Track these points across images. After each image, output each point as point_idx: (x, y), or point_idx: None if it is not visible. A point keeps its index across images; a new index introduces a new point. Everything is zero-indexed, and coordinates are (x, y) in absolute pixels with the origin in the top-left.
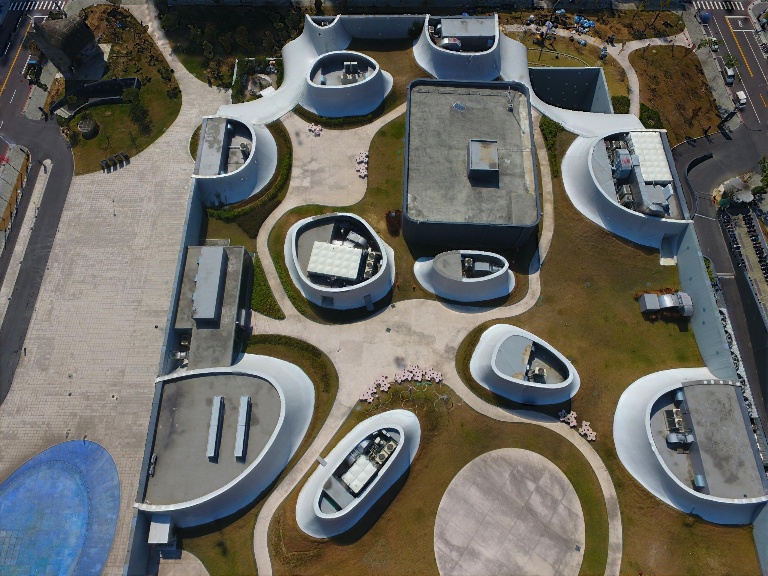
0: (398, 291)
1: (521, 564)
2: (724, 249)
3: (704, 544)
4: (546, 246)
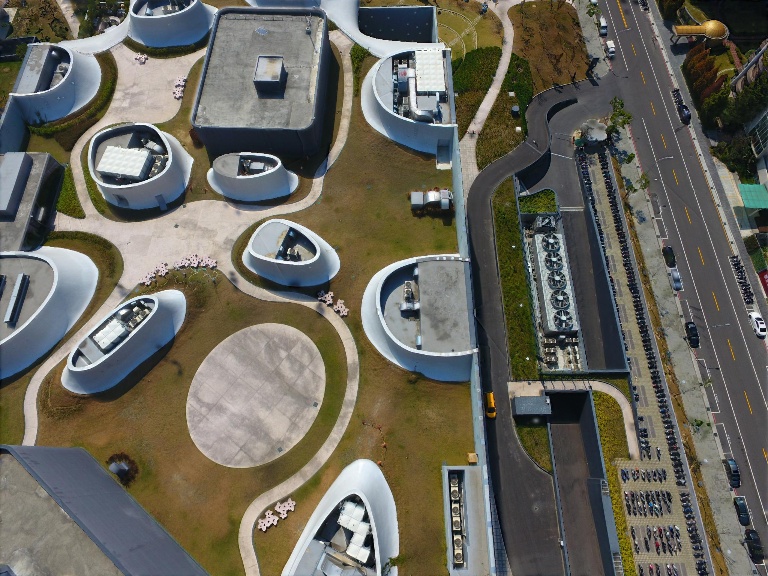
0: (191, 193)
1: (262, 417)
2: (577, 185)
3: (426, 398)
4: (335, 155)
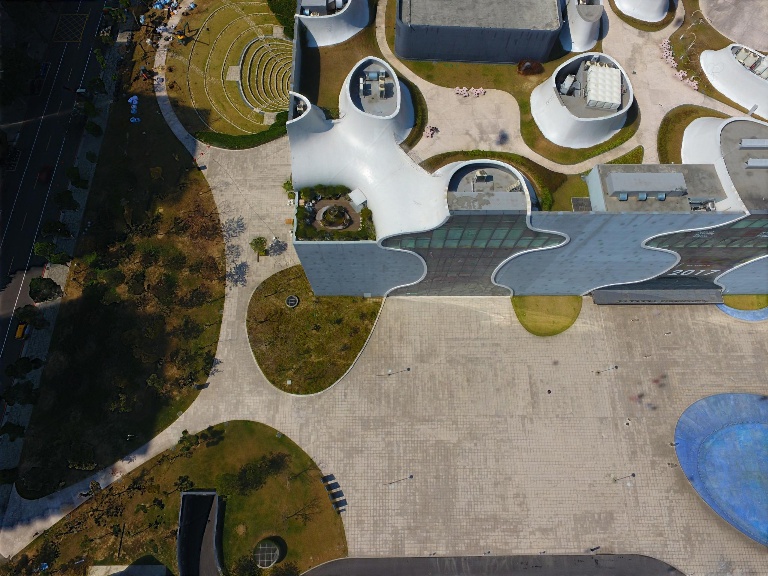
0: None
1: None
2: None
3: None
4: None
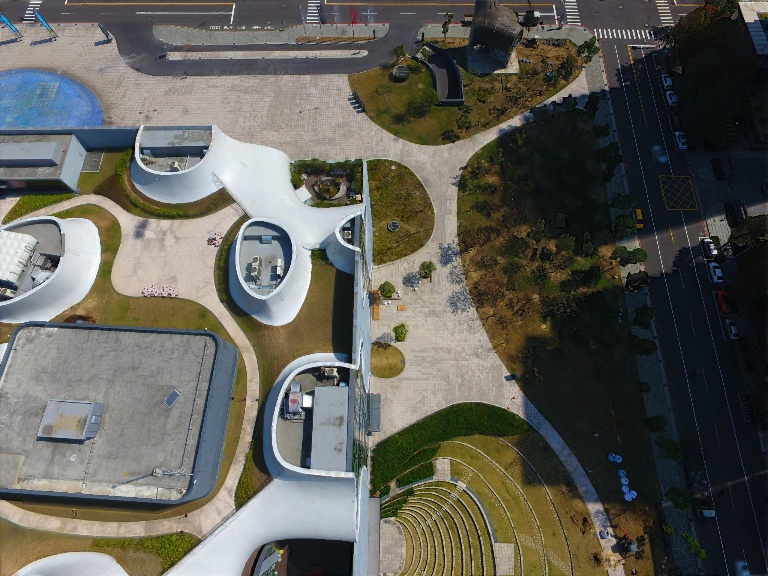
0: None
1: None
2: None
3: None
4: None
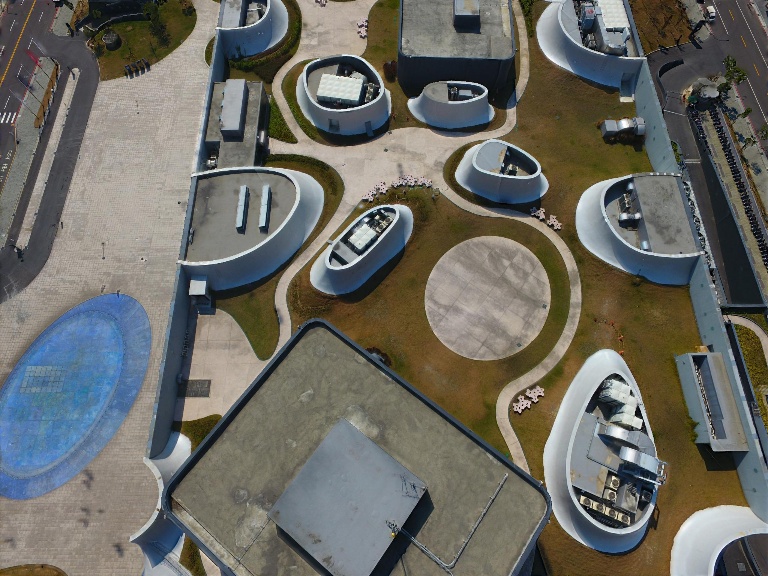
0: (394, 121)
1: (497, 317)
2: (692, 139)
3: (649, 300)
4: (522, 89)
